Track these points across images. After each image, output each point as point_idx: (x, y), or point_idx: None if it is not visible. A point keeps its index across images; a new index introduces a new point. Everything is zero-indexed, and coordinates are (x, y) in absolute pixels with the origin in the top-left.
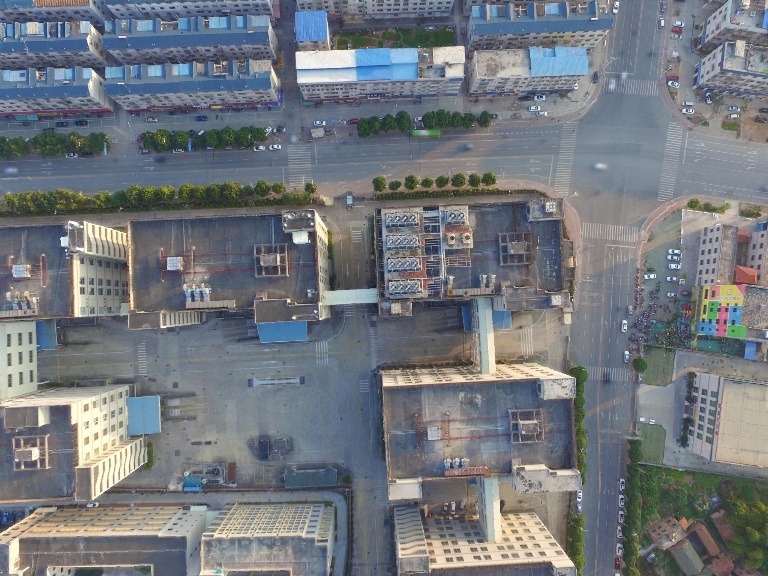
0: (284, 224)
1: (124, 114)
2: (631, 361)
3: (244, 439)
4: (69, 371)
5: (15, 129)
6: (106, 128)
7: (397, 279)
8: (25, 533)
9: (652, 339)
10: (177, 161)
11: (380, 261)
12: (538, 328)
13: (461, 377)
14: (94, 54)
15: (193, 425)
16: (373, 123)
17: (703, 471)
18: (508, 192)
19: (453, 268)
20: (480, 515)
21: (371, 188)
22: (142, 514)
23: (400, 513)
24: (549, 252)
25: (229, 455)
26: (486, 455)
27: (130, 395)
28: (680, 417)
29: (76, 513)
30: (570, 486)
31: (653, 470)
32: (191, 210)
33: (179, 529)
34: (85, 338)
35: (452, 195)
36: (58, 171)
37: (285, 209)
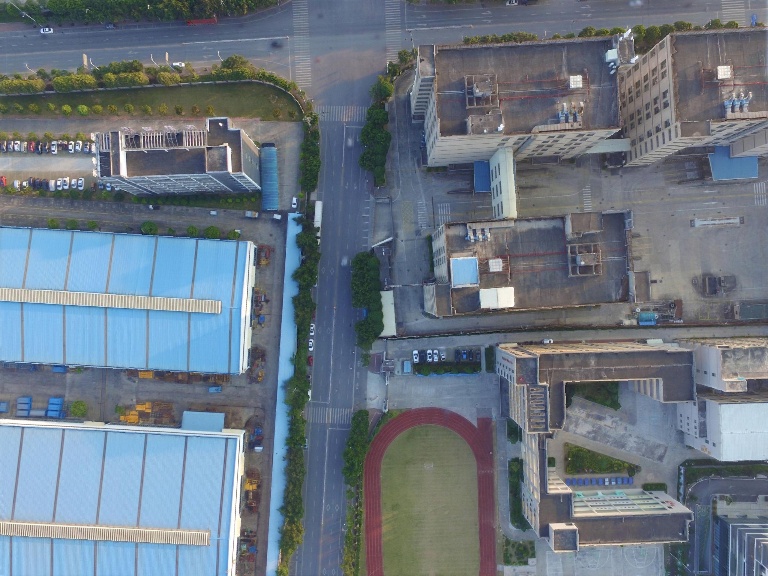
0: None
1: None
2: None
3: (688, 277)
4: (518, 214)
5: None
6: None
7: None
8: (534, 352)
9: None
10: (613, 8)
11: None
12: None
13: None
14: None
15: (639, 265)
16: None
17: None
18: None
19: None
20: None
21: None
22: None
23: None
24: None
25: (674, 293)
26: None
27: None
28: None
29: (542, 346)
30: None
31: None
32: None
33: None
34: (531, 182)
35: None
36: (498, 19)
37: None
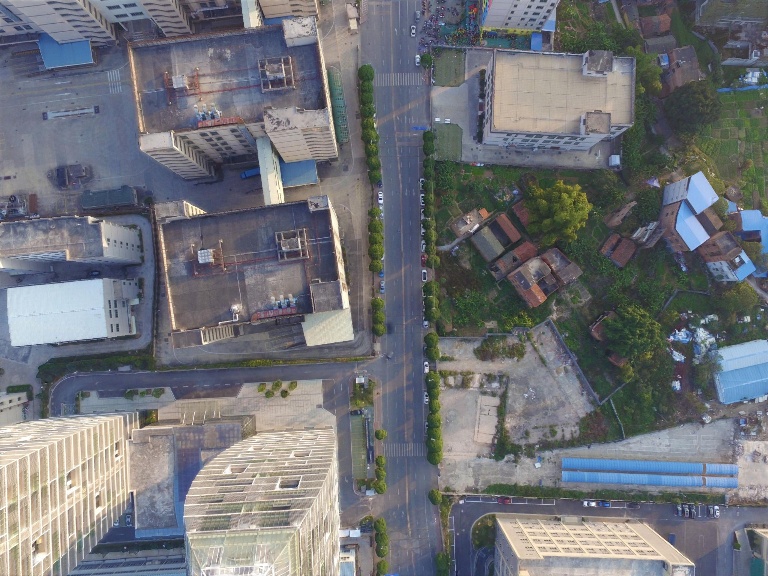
0: None
1: None
2: None
3: (43, 171)
4: None
5: None
6: None
7: None
8: None
9: None
10: None
11: None
12: (328, 40)
13: None
14: None
15: None
16: None
17: (500, 163)
18: None
19: None
20: None
21: None
22: None
23: None
24: None
25: (29, 188)
26: (240, 107)
27: None
28: (475, 115)
29: None
30: (318, 121)
31: (448, 162)
32: None
33: None
34: None
35: None
36: None
37: None
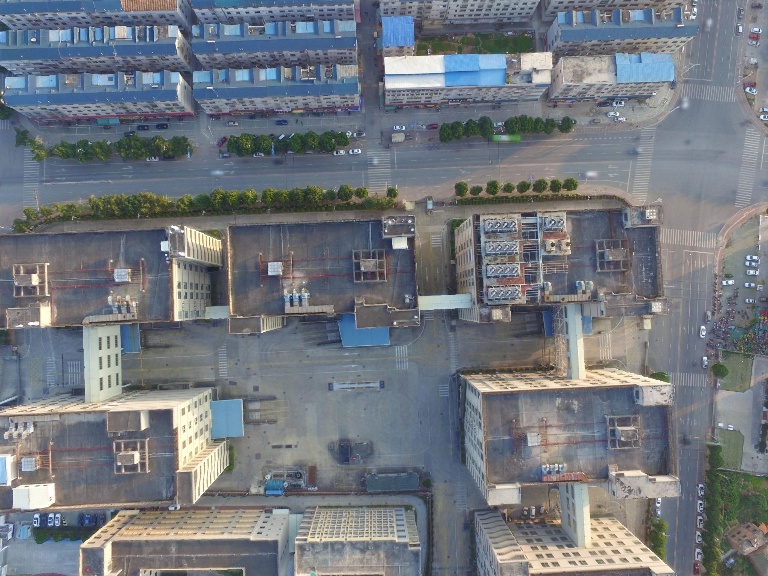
0: (385, 230)
1: (204, 118)
2: (709, 367)
3: (324, 443)
4: (150, 374)
5: (96, 132)
6: (186, 132)
7: (496, 285)
8: (116, 536)
9: (731, 345)
10: (257, 165)
11: (479, 267)
12: (617, 333)
13: (553, 383)
14: (180, 58)
15: (274, 428)
16: (457, 128)
17: None
18: (587, 197)
19: (550, 274)
20: (564, 520)
21: (450, 193)
22: (226, 517)
23: (483, 517)
24: (645, 259)
25: (309, 459)
26: (583, 461)
27: (213, 398)
28: (758, 423)
29: (159, 516)
30: (669, 492)
31: (733, 476)
32: (271, 214)
33: (268, 533)
34: (166, 341)
35: (531, 200)
36: (139, 174)
37: (365, 213)
